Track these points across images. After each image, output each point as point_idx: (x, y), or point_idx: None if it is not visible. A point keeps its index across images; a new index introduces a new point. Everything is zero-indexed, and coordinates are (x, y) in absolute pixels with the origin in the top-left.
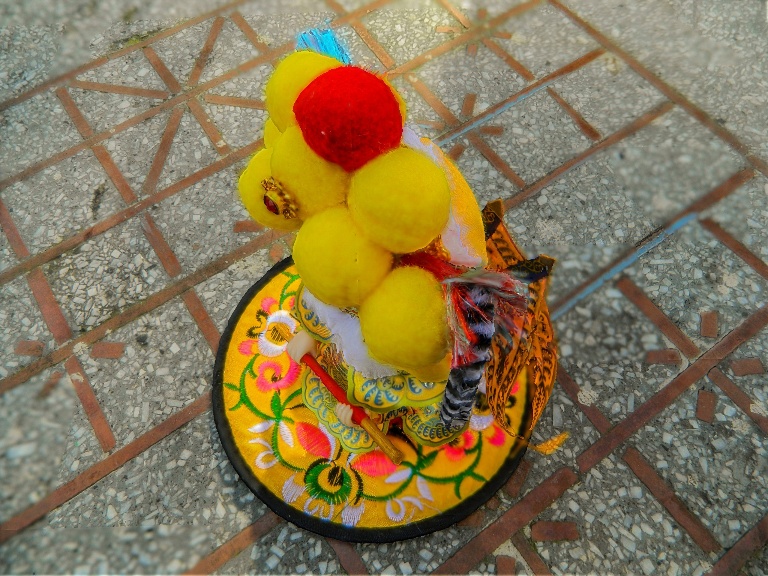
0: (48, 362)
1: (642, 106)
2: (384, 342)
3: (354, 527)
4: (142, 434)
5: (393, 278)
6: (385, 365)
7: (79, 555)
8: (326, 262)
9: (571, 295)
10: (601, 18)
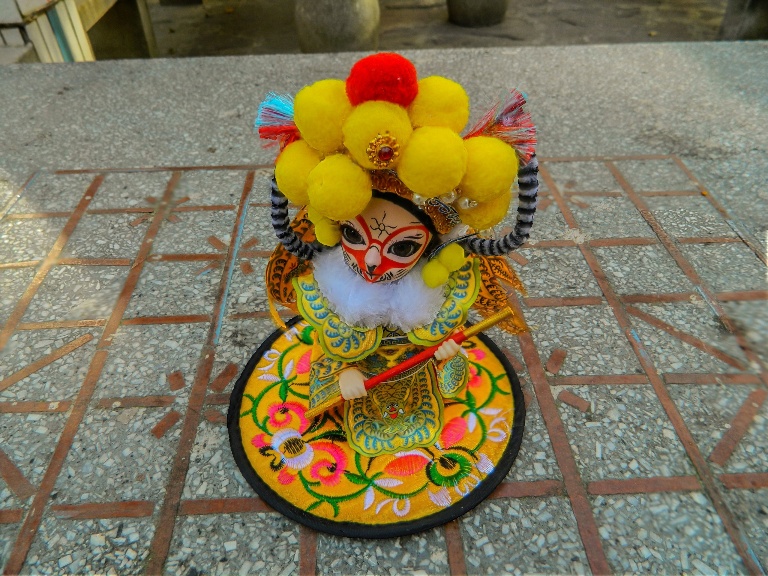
0: None
1: None
2: (500, 169)
3: (495, 468)
4: None
5: None
6: (438, 295)
7: None
8: (448, 147)
9: None
10: (228, 159)
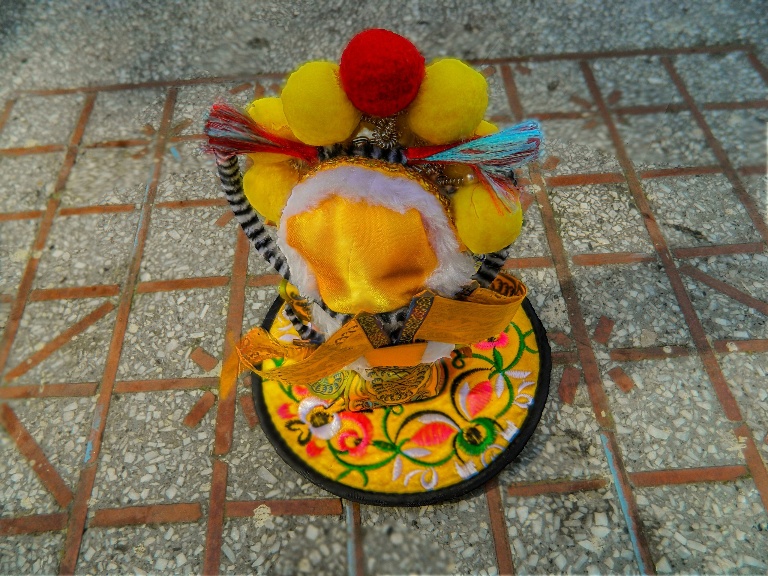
0: (534, 170)
1: None
2: None
3: None
4: None
5: None
6: None
7: None
8: None
9: None
10: None
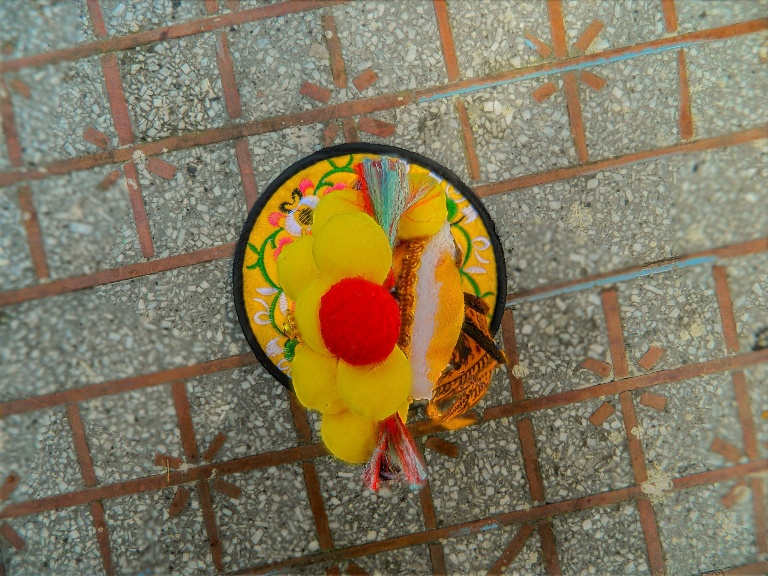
0: (110, 158)
1: (758, 117)
2: (329, 446)
3: None
4: (175, 255)
5: (350, 416)
6: None
7: (114, 325)
8: (307, 397)
9: (560, 286)
10: None
